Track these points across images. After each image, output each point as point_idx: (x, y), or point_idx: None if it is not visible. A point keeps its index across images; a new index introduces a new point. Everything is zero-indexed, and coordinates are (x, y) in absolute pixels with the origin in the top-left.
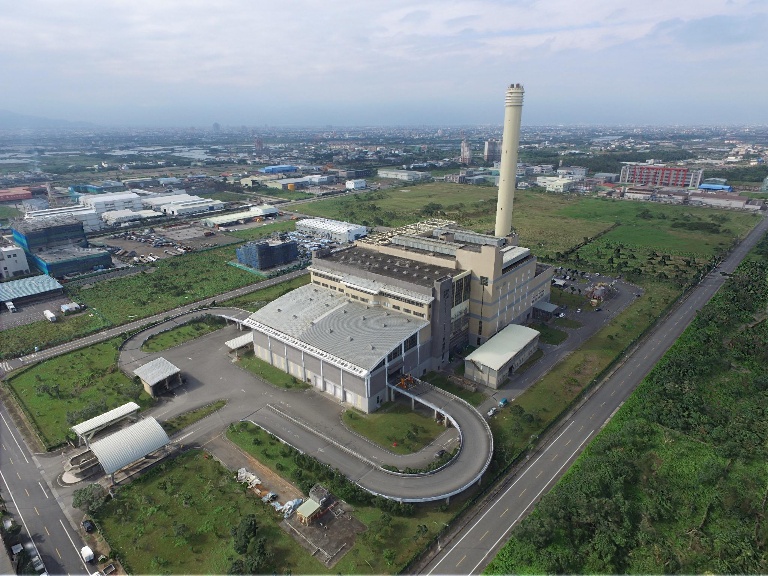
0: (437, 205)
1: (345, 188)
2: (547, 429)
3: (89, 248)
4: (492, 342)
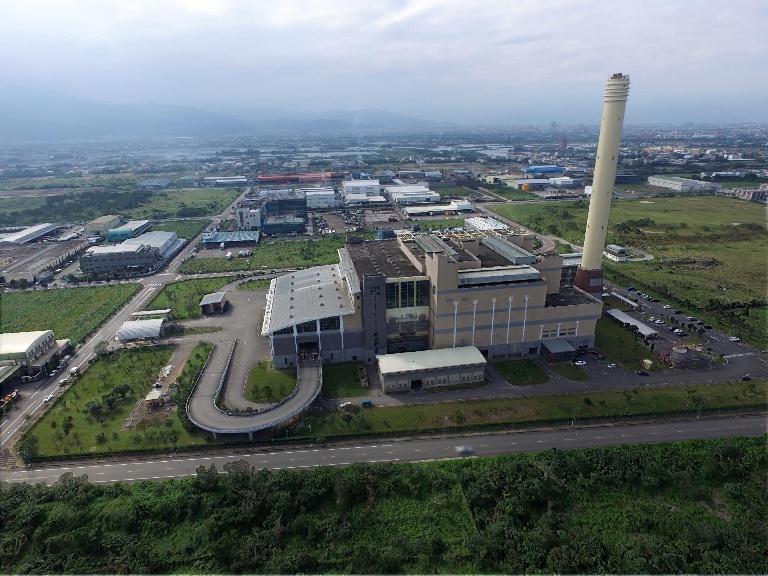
0: (645, 221)
1: (582, 193)
2: (360, 436)
3: (298, 217)
4: (421, 352)
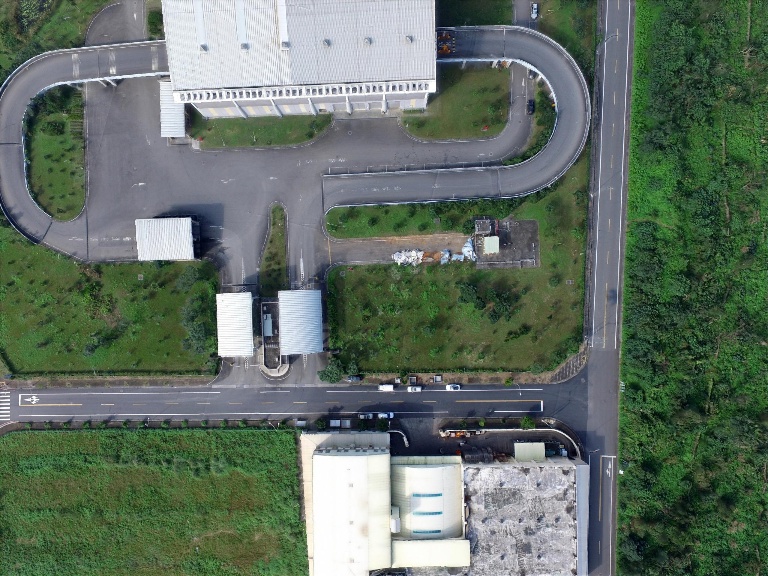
0: None
1: None
2: None
3: None
4: None
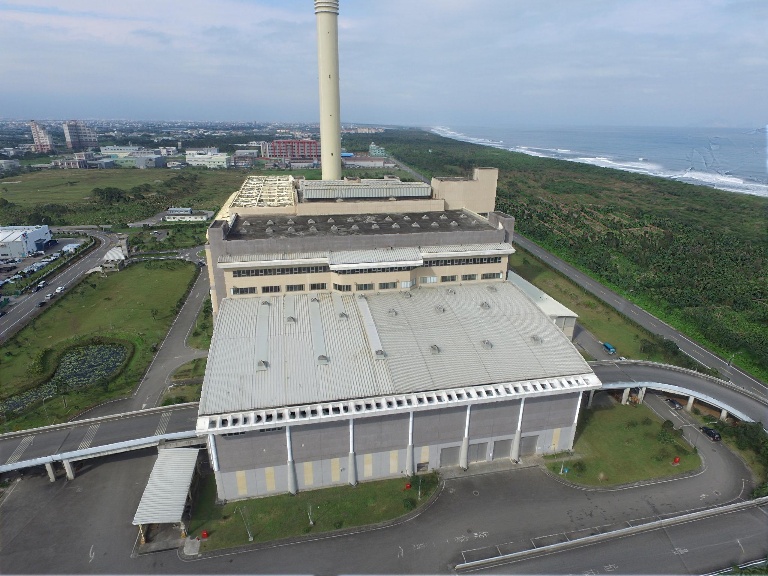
0: (115, 189)
1: None
2: None
3: None
4: None
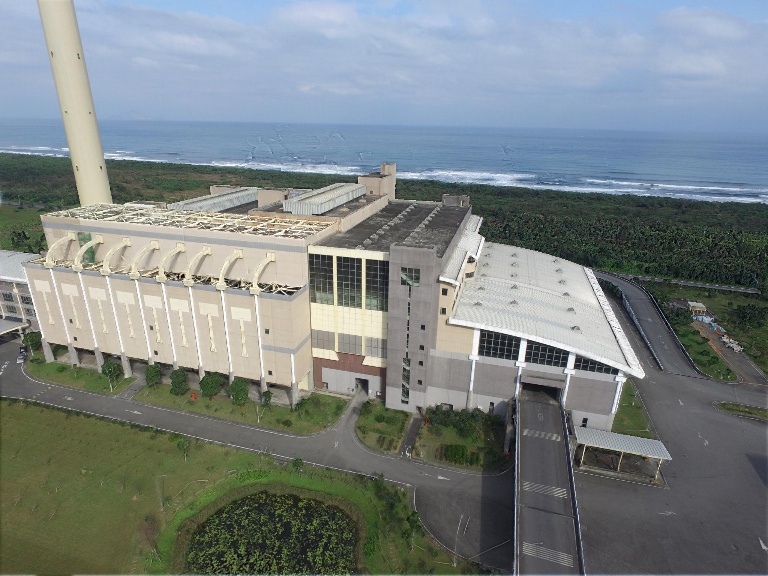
0: None
1: None
2: None
3: None
4: None
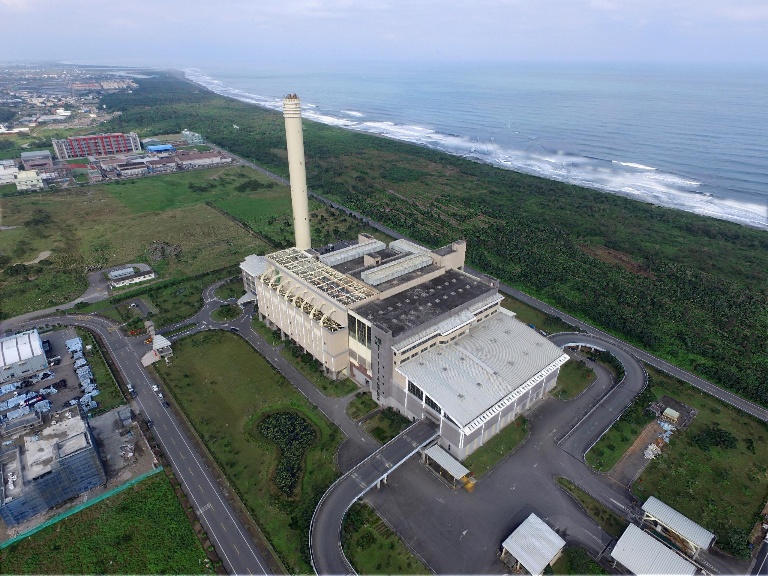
0: None
1: None
2: None
3: None
4: None
